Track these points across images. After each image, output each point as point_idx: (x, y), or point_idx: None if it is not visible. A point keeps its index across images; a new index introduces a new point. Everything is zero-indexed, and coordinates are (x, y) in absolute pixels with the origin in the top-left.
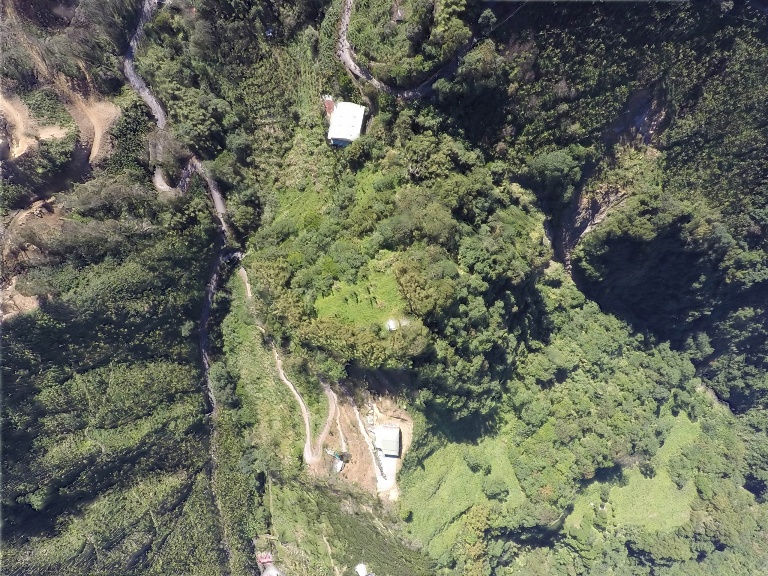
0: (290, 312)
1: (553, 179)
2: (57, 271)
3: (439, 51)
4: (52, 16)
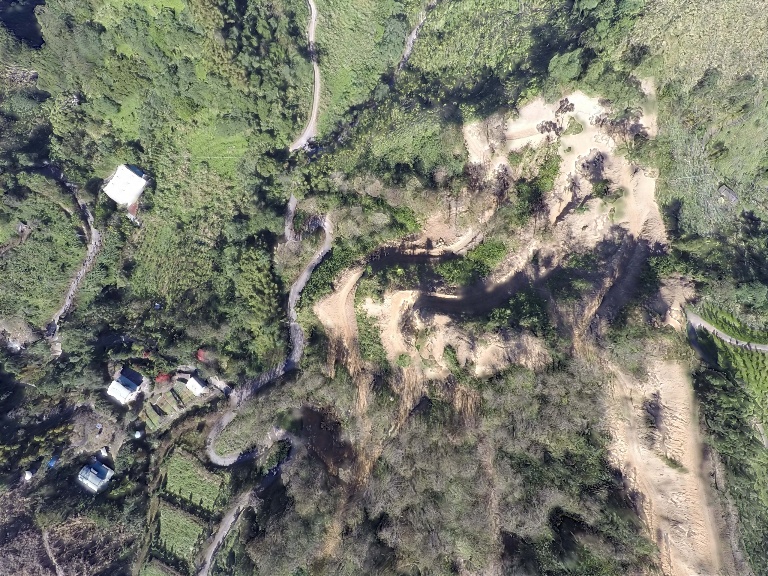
0: (205, 5)
1: (38, 95)
2: (441, 166)
3: (5, 179)
4: (334, 437)
